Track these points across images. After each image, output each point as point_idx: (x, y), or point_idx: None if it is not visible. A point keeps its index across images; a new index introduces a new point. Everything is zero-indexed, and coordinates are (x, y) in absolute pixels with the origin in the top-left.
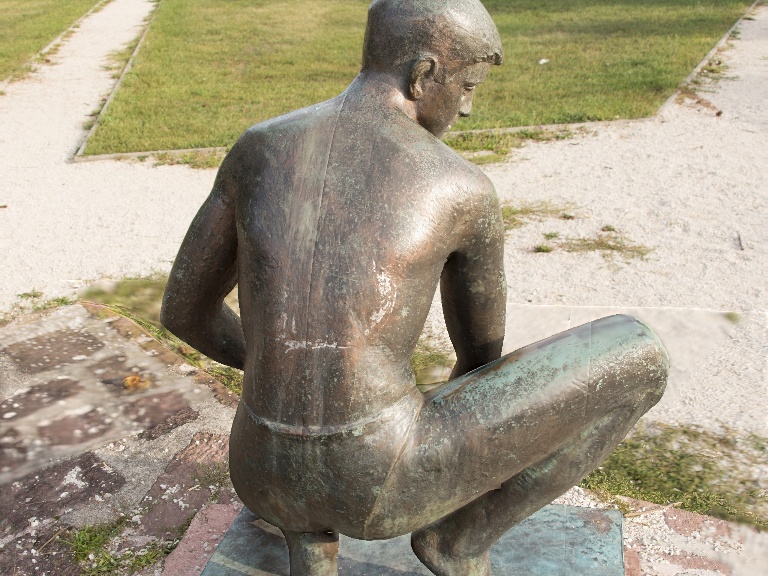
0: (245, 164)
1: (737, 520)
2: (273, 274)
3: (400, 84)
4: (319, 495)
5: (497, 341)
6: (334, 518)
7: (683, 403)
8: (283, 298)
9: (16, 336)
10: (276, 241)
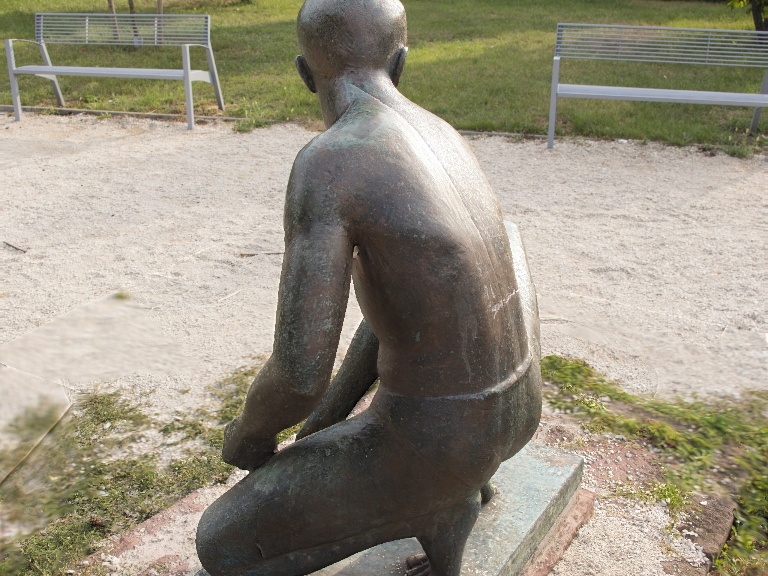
0: (370, 178)
1: (369, 391)
2: (466, 257)
3: (389, 77)
4: None
5: None
6: None
7: (207, 362)
8: (480, 273)
9: None
10: (455, 228)
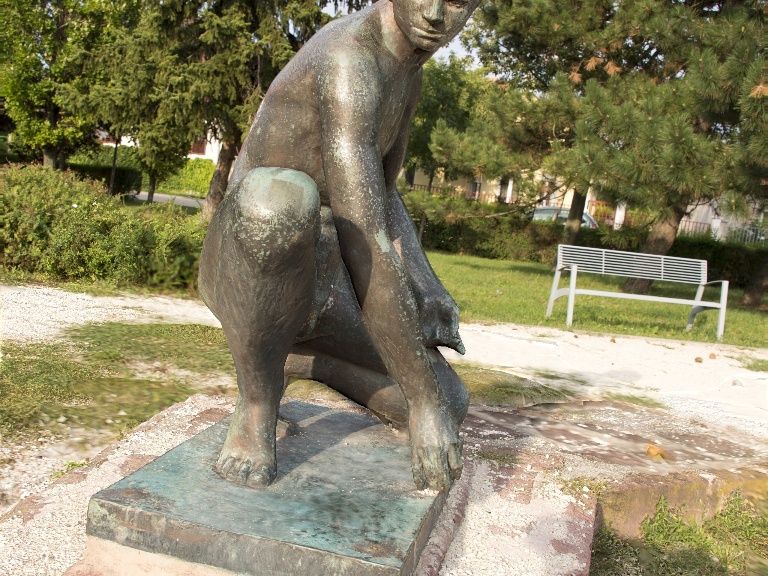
0: None
1: None
2: None
3: None
4: None
5: (339, 220)
6: None
7: None
8: None
9: (725, 435)
10: None
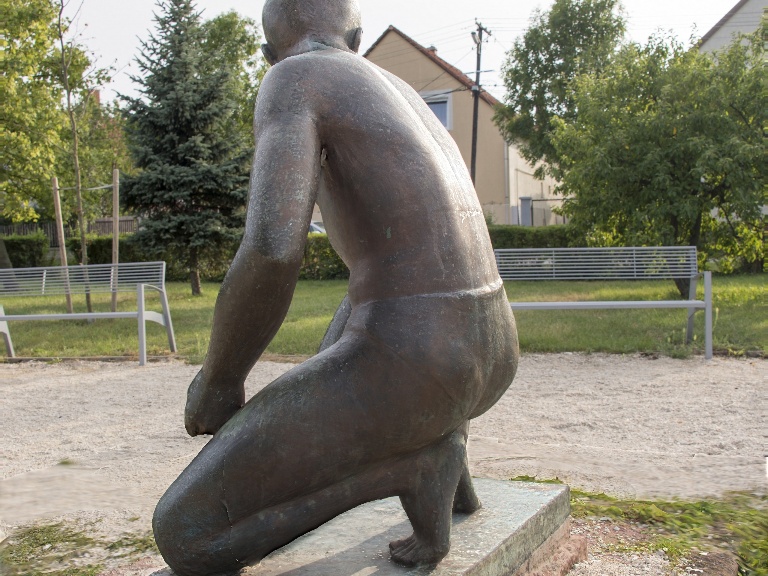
0: (335, 80)
1: None
2: (431, 158)
3: None
4: (501, 350)
5: None
6: (505, 373)
7: None
8: (445, 177)
9: None
10: (418, 132)
